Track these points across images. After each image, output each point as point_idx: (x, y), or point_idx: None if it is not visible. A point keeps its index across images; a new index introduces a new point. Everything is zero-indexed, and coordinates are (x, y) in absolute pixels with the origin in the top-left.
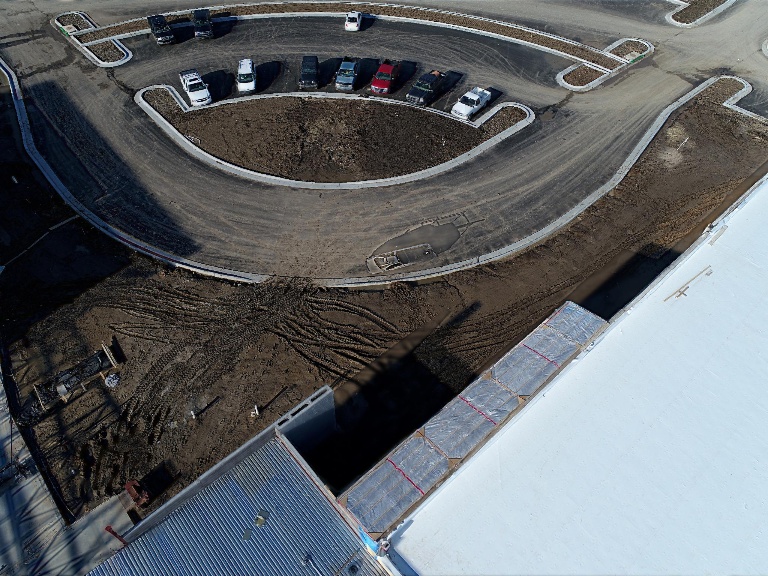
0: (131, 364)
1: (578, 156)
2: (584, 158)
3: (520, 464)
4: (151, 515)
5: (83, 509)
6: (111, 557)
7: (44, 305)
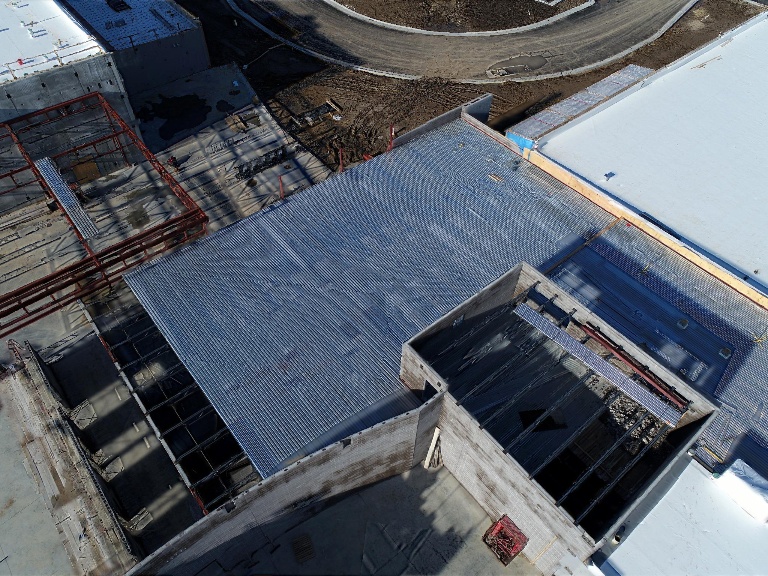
0: (346, 111)
1: (628, 24)
2: (632, 25)
3: (605, 126)
4: (404, 134)
5: (339, 167)
6: (384, 153)
7: (280, 84)
